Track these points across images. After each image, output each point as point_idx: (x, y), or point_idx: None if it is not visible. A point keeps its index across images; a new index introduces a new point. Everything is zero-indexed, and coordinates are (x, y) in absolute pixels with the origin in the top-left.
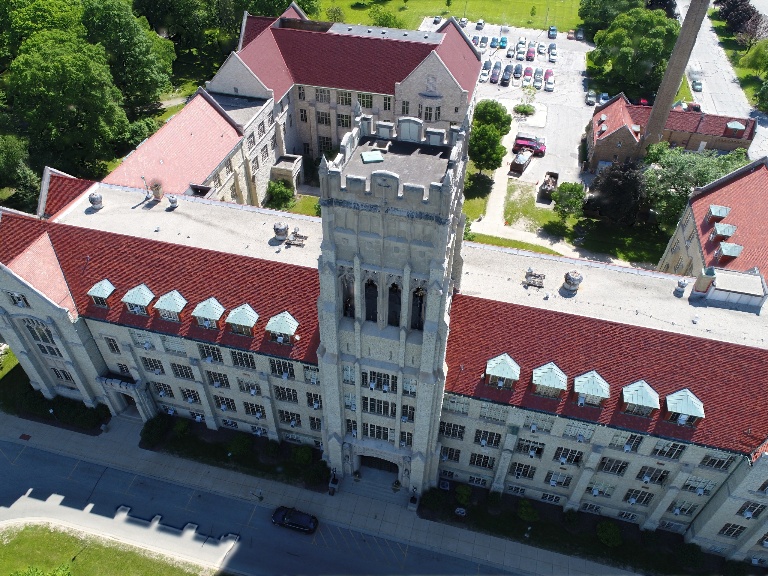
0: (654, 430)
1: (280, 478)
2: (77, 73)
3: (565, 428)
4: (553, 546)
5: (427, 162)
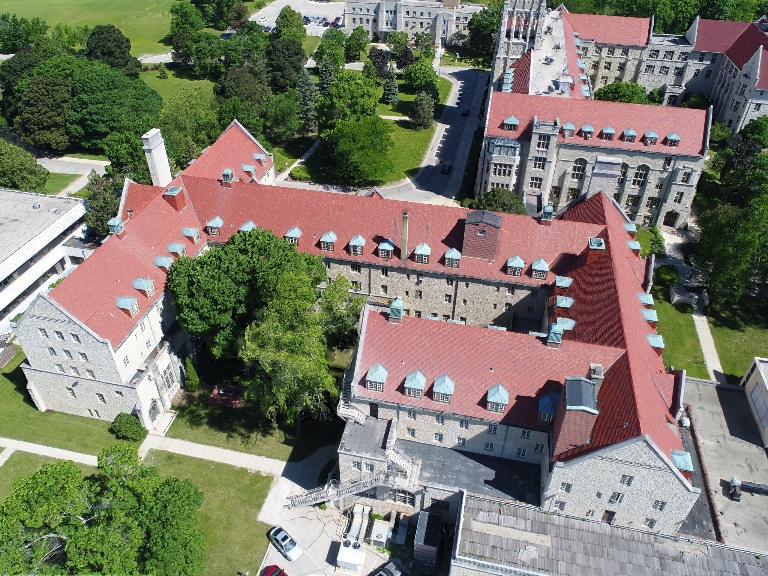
0: None
1: None
2: (650, 5)
3: None
4: None
5: None
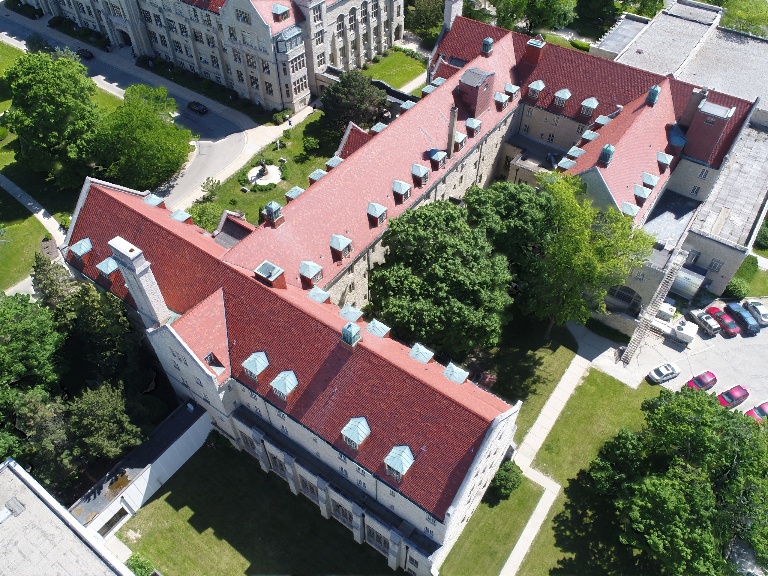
0: (196, 3)
1: (92, 44)
2: None
3: (175, 7)
4: (179, 83)
5: None
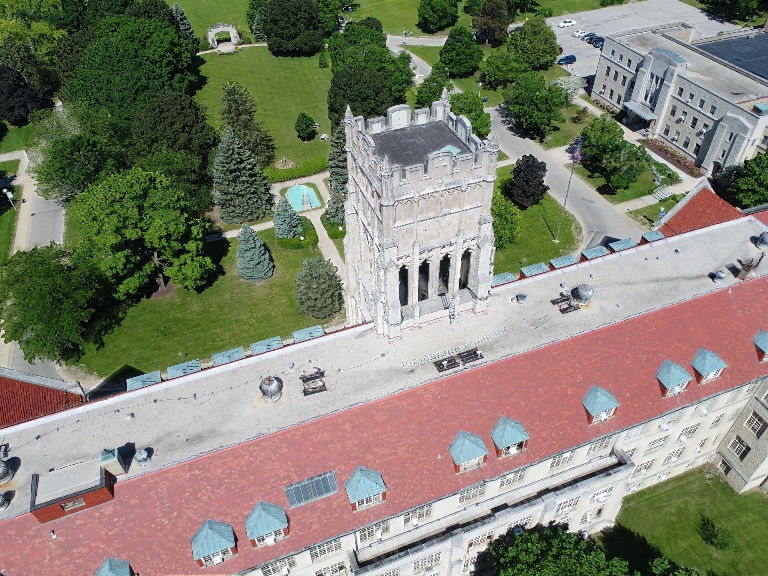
0: None
1: None
2: None
3: None
4: None
5: (403, 167)
